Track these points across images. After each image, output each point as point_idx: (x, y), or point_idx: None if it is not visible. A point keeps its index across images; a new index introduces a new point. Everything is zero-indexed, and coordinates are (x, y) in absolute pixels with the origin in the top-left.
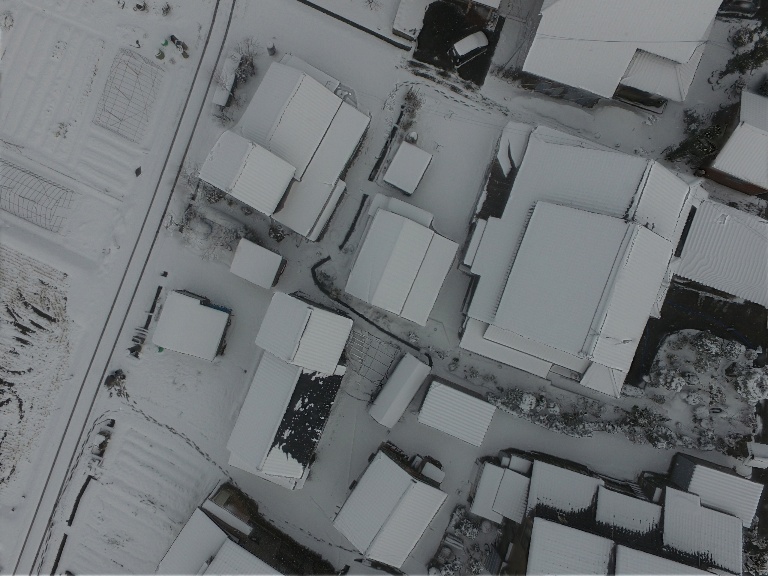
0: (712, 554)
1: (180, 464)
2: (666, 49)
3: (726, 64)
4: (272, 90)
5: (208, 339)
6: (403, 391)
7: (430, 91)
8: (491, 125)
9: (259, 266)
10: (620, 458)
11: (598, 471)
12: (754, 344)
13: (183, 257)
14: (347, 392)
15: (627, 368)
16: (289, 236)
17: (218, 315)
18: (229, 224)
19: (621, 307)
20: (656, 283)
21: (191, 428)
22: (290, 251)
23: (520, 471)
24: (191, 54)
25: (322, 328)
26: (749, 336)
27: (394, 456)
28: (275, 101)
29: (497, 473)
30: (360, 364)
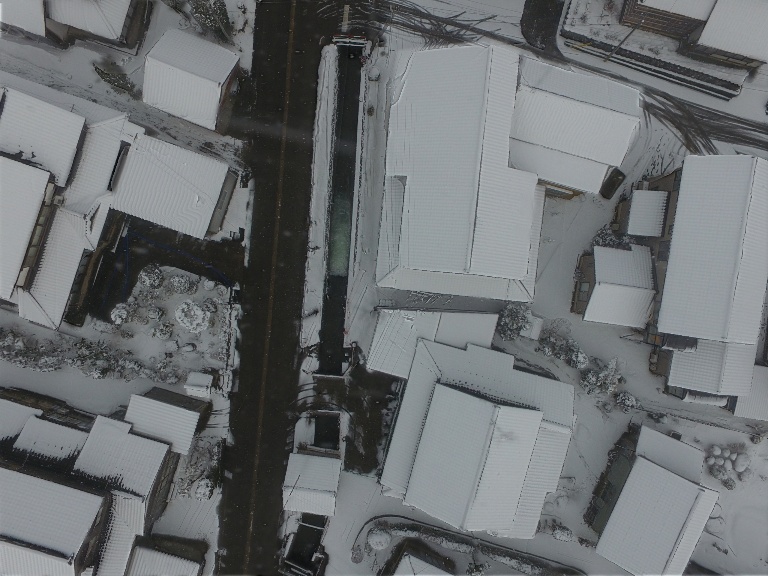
0: (123, 478)
1: None
2: None
3: (163, 3)
4: None
5: None
6: None
7: None
8: None
9: None
10: (98, 393)
11: (75, 406)
12: (231, 281)
13: None
14: None
15: (7, 294)
16: None
17: None
18: None
19: None
20: (29, 210)
21: None
22: None
23: None
24: None
25: None
26: (226, 273)
27: None
28: None
29: None
30: None
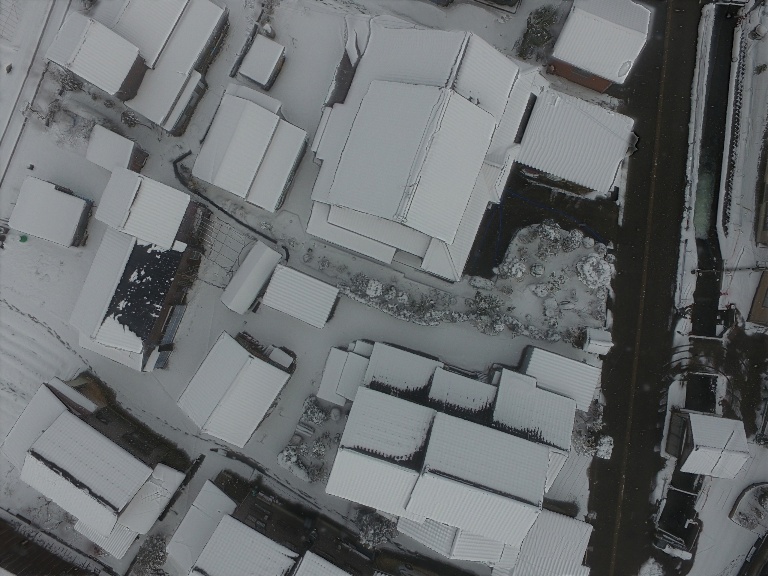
0: (542, 431)
1: (41, 353)
2: None
3: None
4: None
5: (64, 224)
6: (251, 276)
7: None
8: None
9: (113, 152)
10: (471, 350)
11: (449, 362)
12: (605, 239)
13: (48, 150)
14: (205, 283)
15: (451, 240)
16: (151, 130)
17: (74, 201)
18: (90, 116)
19: (438, 174)
20: (478, 155)
21: (52, 317)
22: (152, 145)
23: (363, 355)
24: None
25: (155, 199)
26: (600, 232)
27: (246, 343)
28: None
29: (342, 357)
30: (210, 249)
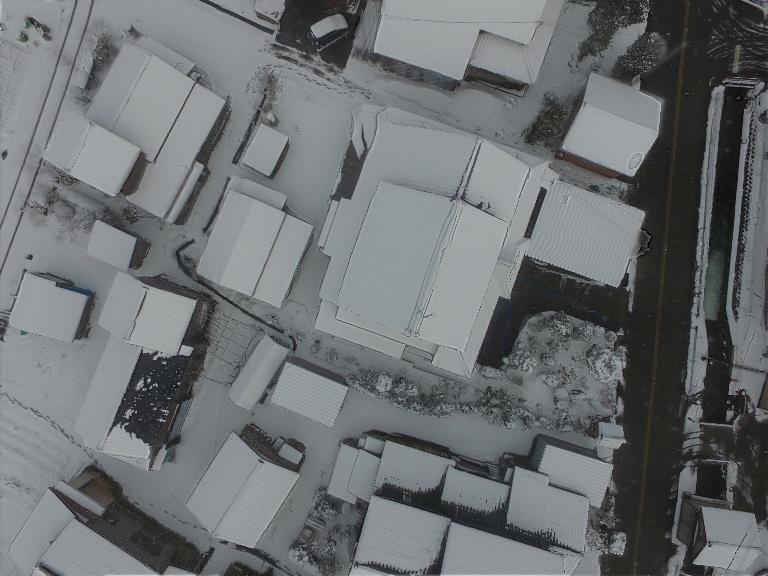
0: (555, 533)
1: (45, 447)
2: (507, 30)
3: (577, 46)
4: (122, 71)
5: (66, 321)
6: (259, 373)
7: (292, 74)
8: (340, 106)
9: (115, 248)
10: (482, 440)
11: (460, 453)
12: (615, 326)
13: (47, 240)
14: (211, 375)
15: (463, 347)
16: (153, 219)
17: (76, 297)
18: (90, 207)
19: (450, 285)
20: (490, 262)
21: (56, 411)
22: (154, 234)
23: (374, 452)
24: (53, 37)
25: (161, 308)
26: (610, 318)
27: (254, 438)
28: (123, 82)
29: (352, 454)
30: (216, 346)
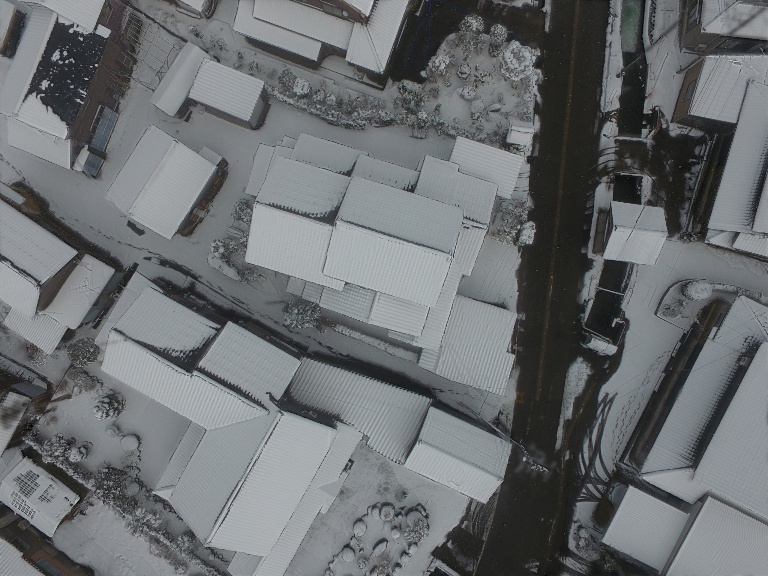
0: None
1: None
2: None
3: None
4: None
5: None
6: (180, 74)
7: None
8: None
9: None
10: (400, 154)
11: None
12: (532, 46)
13: None
14: (137, 93)
15: (367, 10)
16: None
17: (4, 5)
18: None
19: None
20: None
21: None
22: None
23: None
24: None
25: None
26: (527, 38)
27: None
28: None
29: (269, 152)
30: (138, 48)
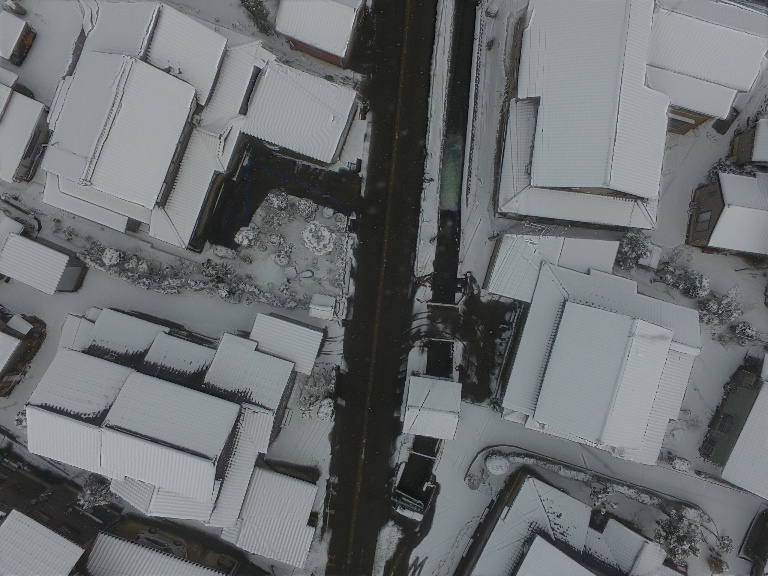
0: (252, 392)
1: None
2: None
3: None
4: None
5: None
6: None
7: None
8: None
9: None
10: (215, 318)
11: (193, 330)
12: (348, 210)
13: None
14: None
15: (151, 204)
16: None
17: None
18: None
19: (127, 139)
20: (176, 123)
21: None
22: None
23: None
24: None
25: None
26: (343, 202)
27: None
28: None
29: (76, 323)
30: None
